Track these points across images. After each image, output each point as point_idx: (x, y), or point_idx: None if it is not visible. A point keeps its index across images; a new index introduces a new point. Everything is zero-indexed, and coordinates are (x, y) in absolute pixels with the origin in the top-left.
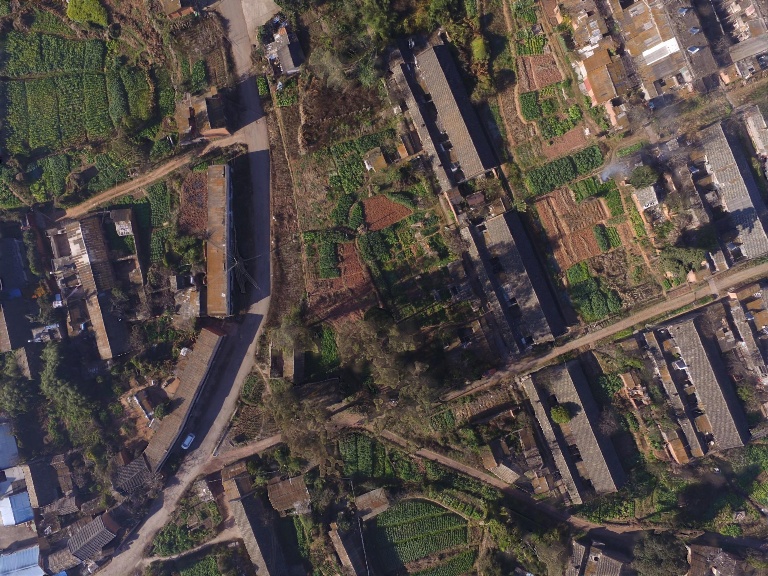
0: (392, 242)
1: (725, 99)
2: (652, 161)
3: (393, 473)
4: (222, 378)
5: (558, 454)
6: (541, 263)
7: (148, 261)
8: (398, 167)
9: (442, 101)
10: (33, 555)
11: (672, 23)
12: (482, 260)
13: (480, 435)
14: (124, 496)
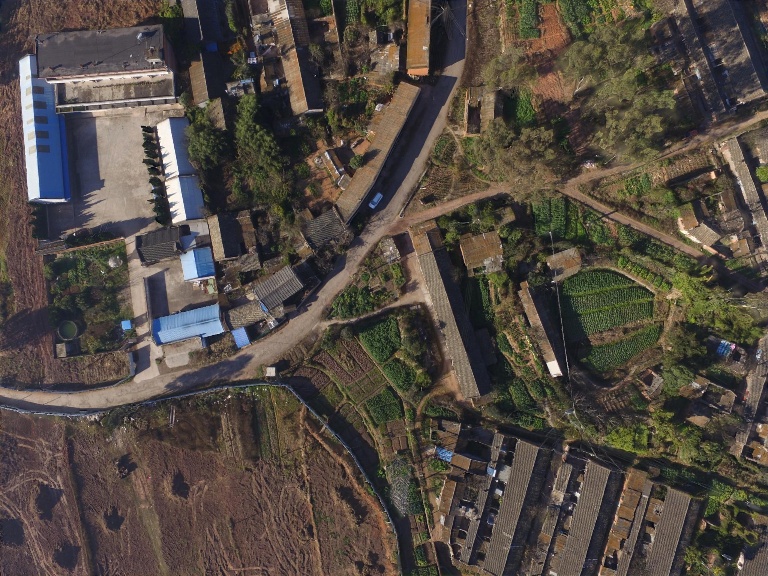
0: (593, 6)
1: None
2: None
3: (586, 235)
4: (413, 139)
5: (761, 216)
6: None
7: (342, 24)
8: None
9: None
10: (212, 311)
11: None
12: (690, 17)
13: (679, 197)
14: (312, 248)
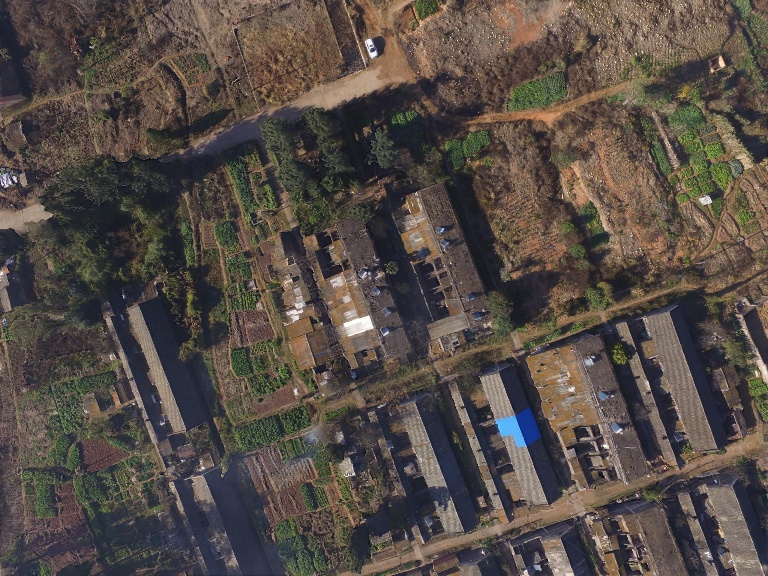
0: (109, 484)
1: (432, 368)
2: (354, 430)
3: None
4: None
5: None
6: (251, 517)
7: None
8: None
9: (150, 356)
10: None
11: (366, 302)
12: (187, 515)
13: None
14: None
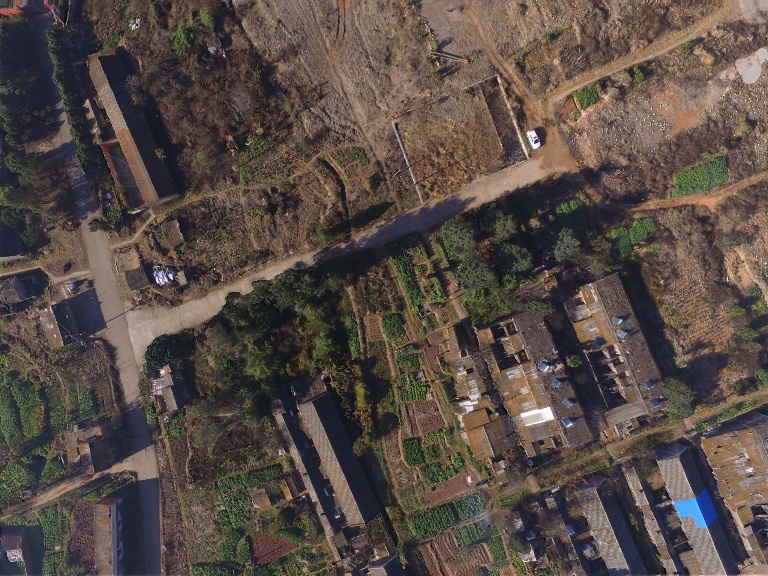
0: (280, 575)
1: (605, 451)
2: (531, 515)
3: None
4: None
5: None
6: None
7: None
8: (284, 505)
9: (324, 452)
10: None
11: (547, 394)
12: None
13: None
14: None
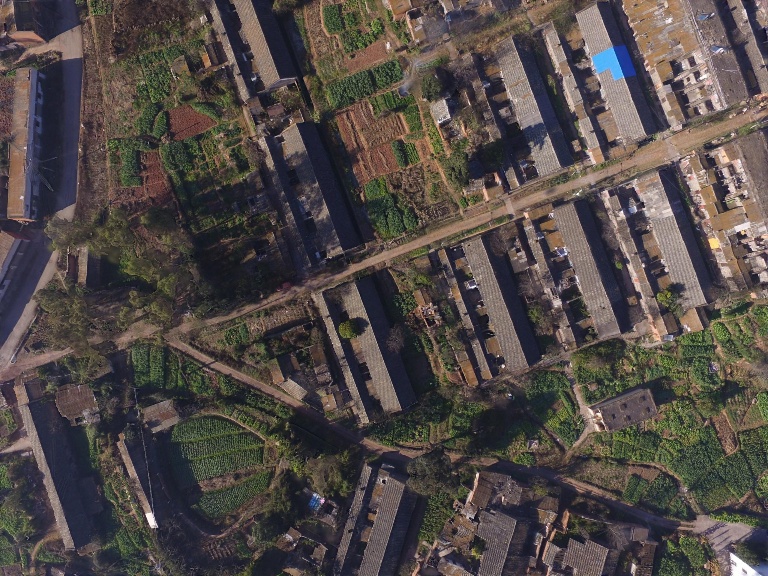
0: (196, 153)
1: (526, 17)
2: (448, 75)
3: (185, 386)
4: (24, 284)
5: (347, 371)
6: (340, 177)
7: None
8: (203, 77)
9: (243, 9)
10: None
11: None
12: (277, 171)
13: (272, 350)
14: None
